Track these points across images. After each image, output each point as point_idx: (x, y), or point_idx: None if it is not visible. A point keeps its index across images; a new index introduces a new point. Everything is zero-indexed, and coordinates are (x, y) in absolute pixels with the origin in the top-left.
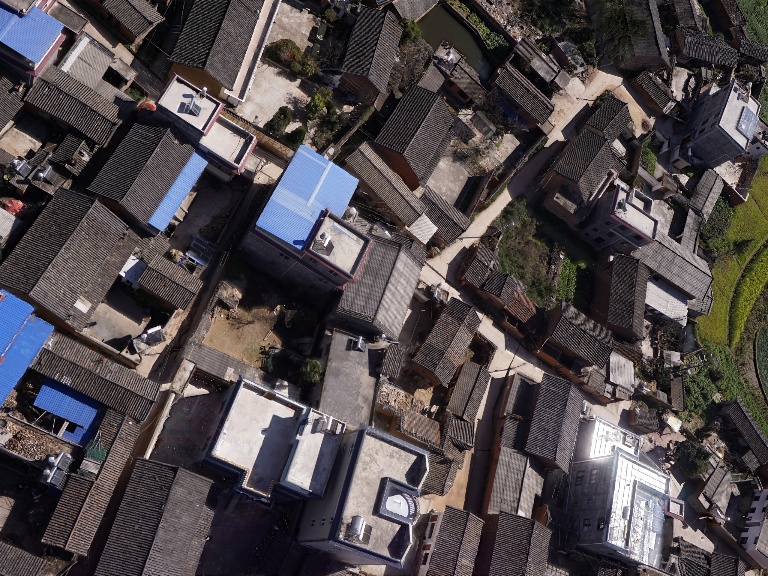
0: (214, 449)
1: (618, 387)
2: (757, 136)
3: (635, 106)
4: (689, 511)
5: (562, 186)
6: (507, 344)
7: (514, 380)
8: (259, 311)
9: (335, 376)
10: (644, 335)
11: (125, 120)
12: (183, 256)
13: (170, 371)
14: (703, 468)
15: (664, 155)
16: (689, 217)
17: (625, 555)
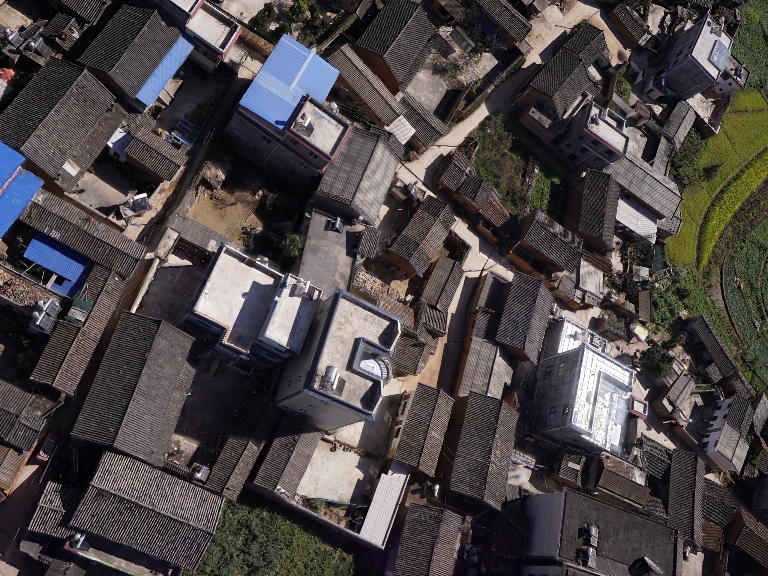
0: (196, 305)
1: (587, 293)
2: (729, 72)
3: (612, 37)
4: (653, 415)
5: (538, 101)
6: (481, 247)
7: (487, 278)
8: (242, 194)
9: (313, 253)
10: (614, 251)
11: (114, 2)
12: (169, 135)
13: (155, 241)
14: (667, 372)
15: (639, 85)
16: (661, 144)
17: (589, 440)
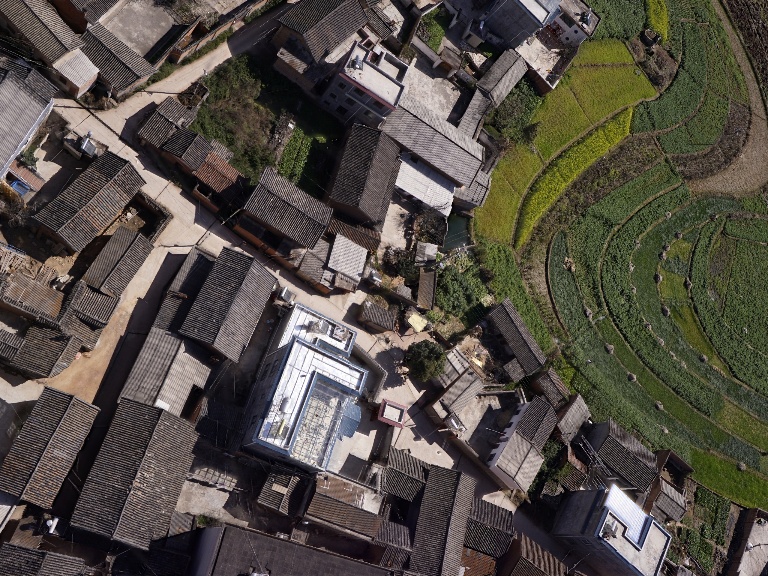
0: None
1: (339, 274)
2: (573, 17)
3: None
4: (426, 422)
5: (289, 40)
6: (198, 217)
7: (189, 255)
8: None
9: None
10: (397, 224)
11: None
12: None
13: None
14: (436, 370)
15: (456, 30)
16: (475, 99)
17: (293, 458)
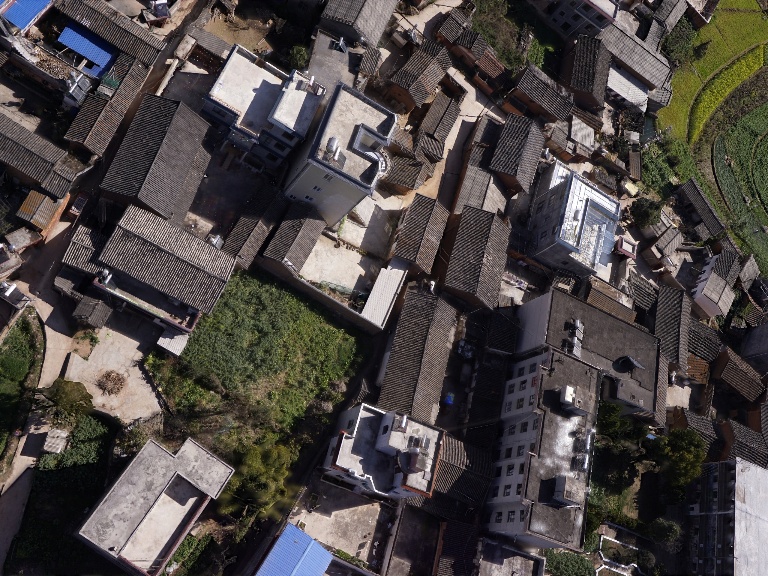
0: (211, 90)
1: (579, 145)
2: None
3: None
4: (643, 263)
5: None
6: (478, 97)
7: (482, 119)
8: (253, 21)
9: (319, 66)
10: (607, 117)
11: None
12: None
13: (174, 50)
14: (655, 218)
15: None
16: (653, 26)
17: (577, 260)
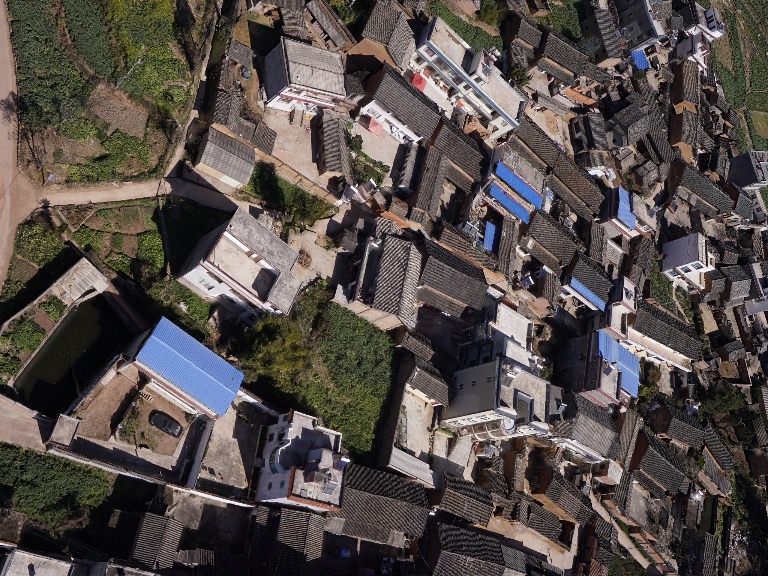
0: (503, 304)
1: None
2: None
3: None
4: None
5: None
6: (568, 571)
7: (558, 568)
8: (540, 356)
9: None
10: None
11: None
12: None
13: None
14: None
15: None
16: None
17: None
